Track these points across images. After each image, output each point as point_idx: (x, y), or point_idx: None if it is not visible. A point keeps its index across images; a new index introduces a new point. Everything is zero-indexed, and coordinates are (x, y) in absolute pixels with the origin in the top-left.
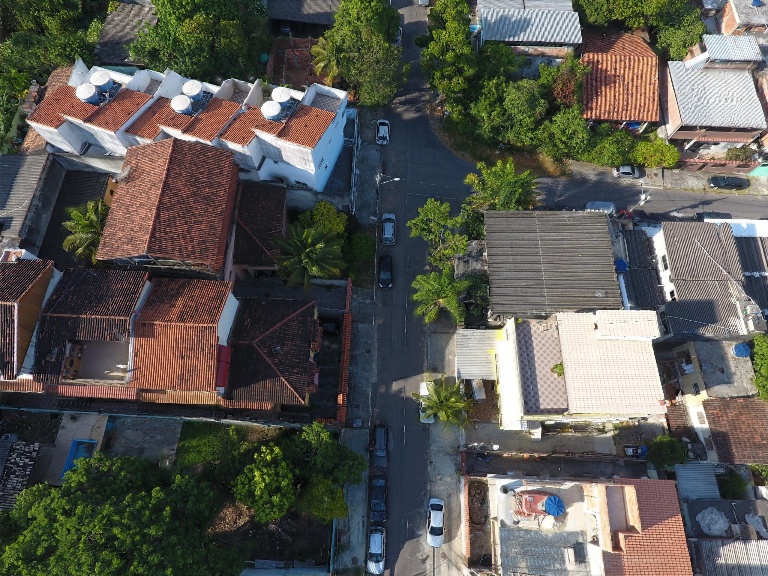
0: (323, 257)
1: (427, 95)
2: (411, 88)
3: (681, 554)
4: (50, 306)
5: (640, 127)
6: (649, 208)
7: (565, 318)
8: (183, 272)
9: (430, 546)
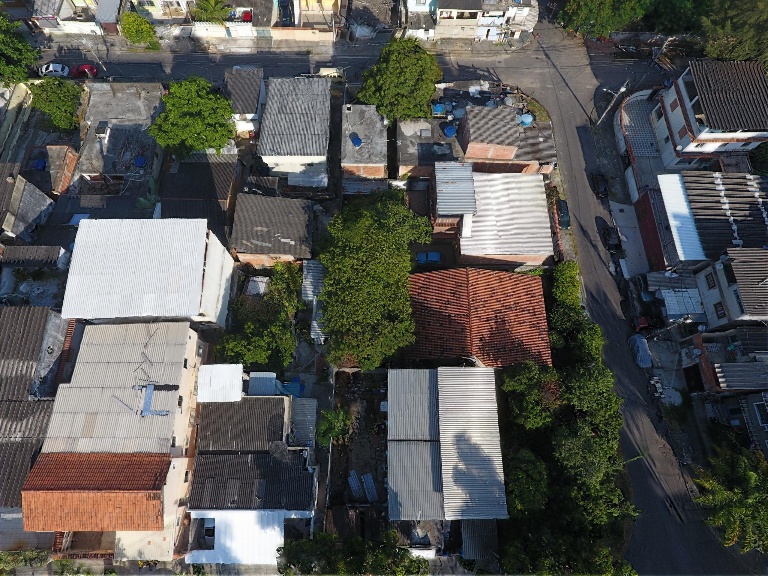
0: None
1: None
2: None
3: None
4: None
5: None
6: (615, 296)
7: None
8: None
9: None
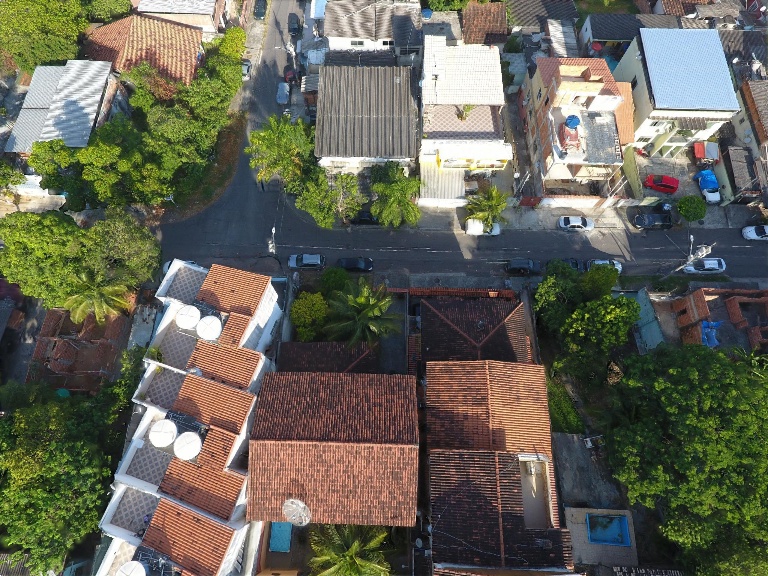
0: None
1: None
2: None
3: (582, 61)
4: (490, 560)
5: (200, 51)
6: (282, 62)
7: (427, 99)
8: None
9: (592, 230)
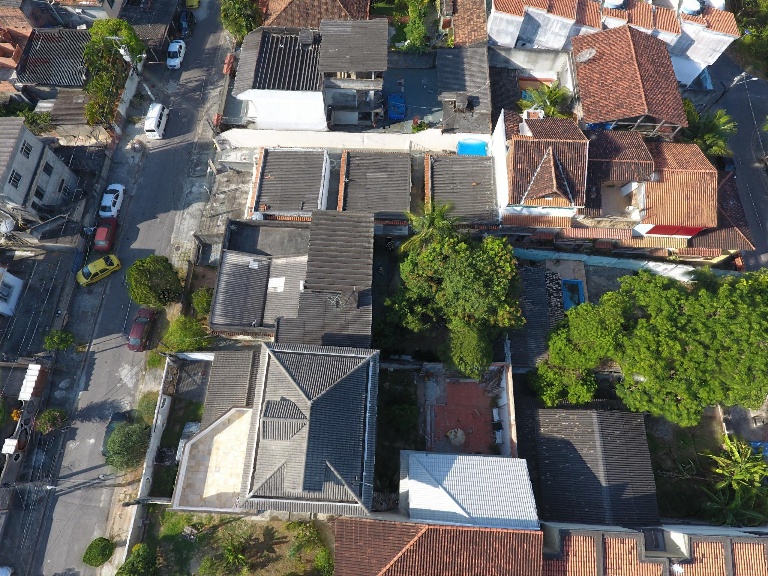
0: None
1: None
2: None
3: None
4: None
5: None
6: None
7: None
8: (643, 139)
9: None
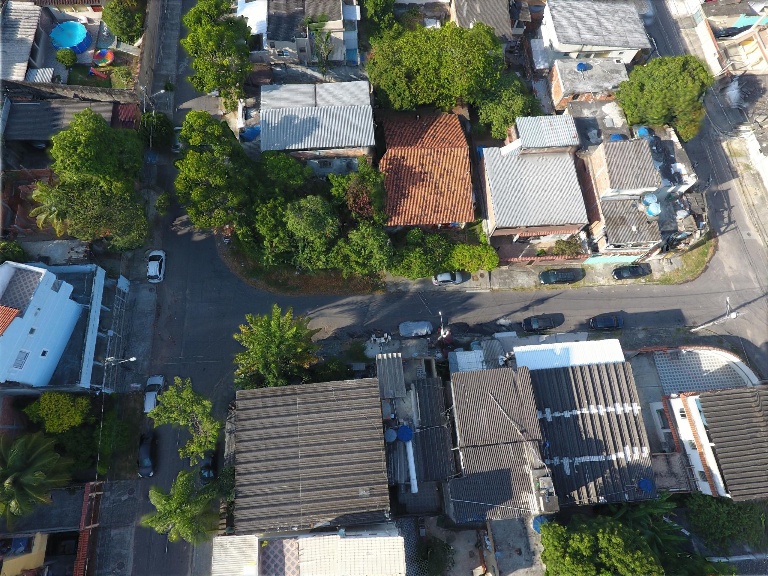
0: (28, 483)
1: None
2: None
3: None
4: None
5: (460, 224)
6: (473, 319)
7: (308, 546)
8: None
9: None
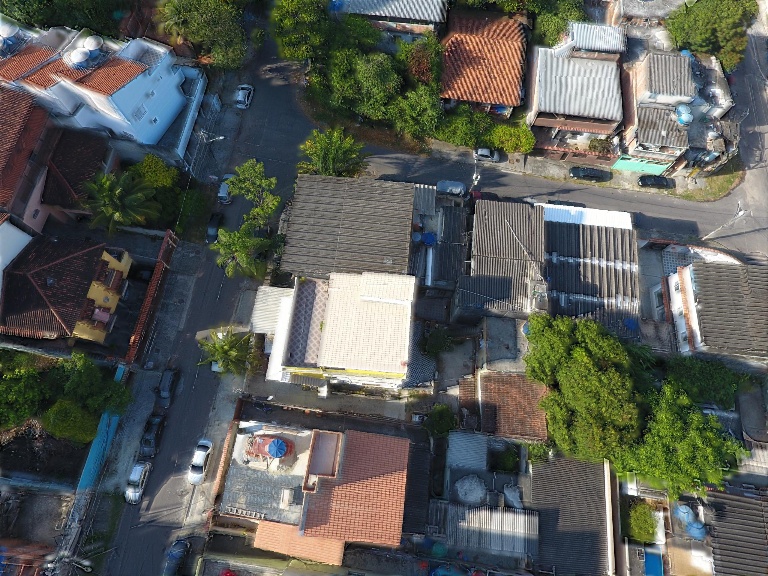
0: (130, 204)
1: (299, 65)
2: (284, 57)
3: (395, 506)
4: None
5: (507, 112)
6: (503, 192)
7: (337, 278)
8: None
9: None
